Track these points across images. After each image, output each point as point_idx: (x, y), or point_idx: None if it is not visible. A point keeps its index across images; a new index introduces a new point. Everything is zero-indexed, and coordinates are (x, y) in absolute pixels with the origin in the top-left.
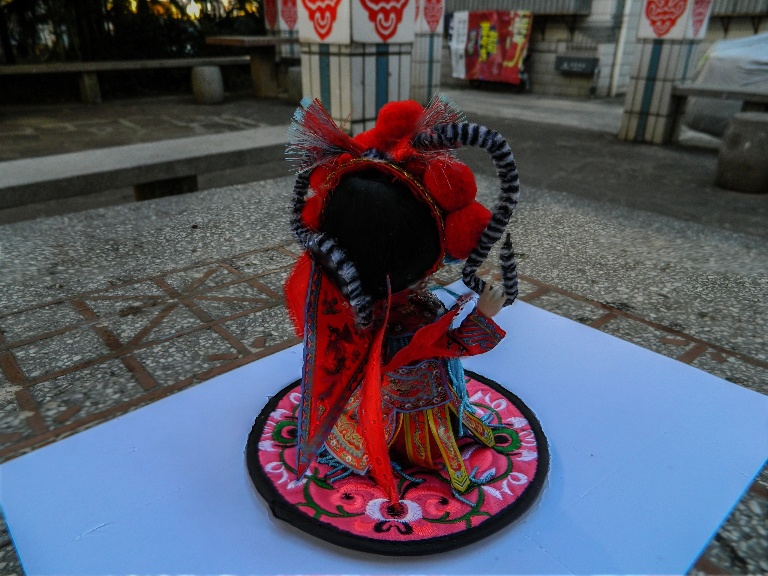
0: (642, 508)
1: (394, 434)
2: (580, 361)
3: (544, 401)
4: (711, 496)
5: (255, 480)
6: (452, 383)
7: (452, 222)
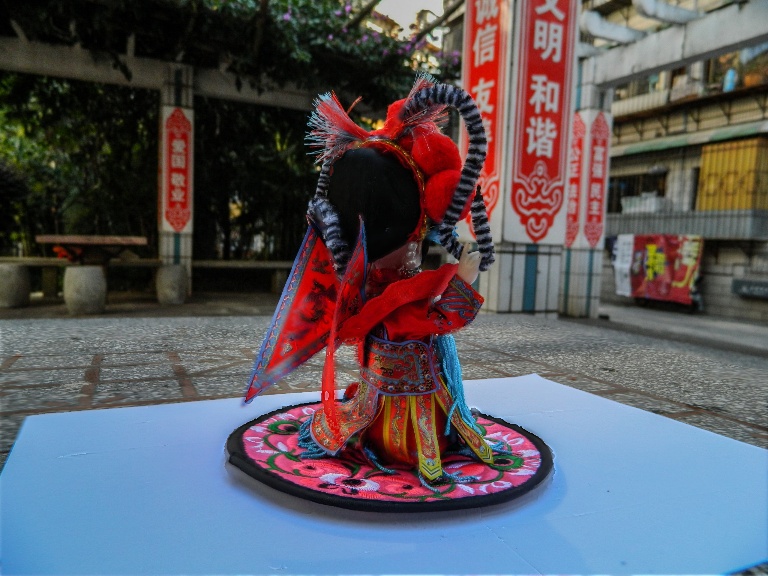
0: (651, 535)
1: (374, 418)
2: (635, 433)
3: (573, 450)
4: (756, 543)
5: (229, 441)
6: (447, 382)
7: (431, 182)
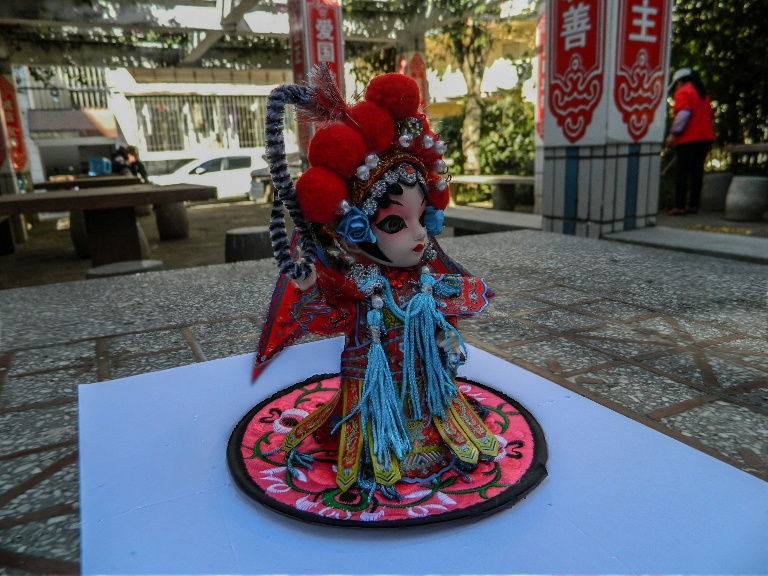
0: None
1: None
2: None
3: (428, 574)
4: None
5: None
6: None
7: None
